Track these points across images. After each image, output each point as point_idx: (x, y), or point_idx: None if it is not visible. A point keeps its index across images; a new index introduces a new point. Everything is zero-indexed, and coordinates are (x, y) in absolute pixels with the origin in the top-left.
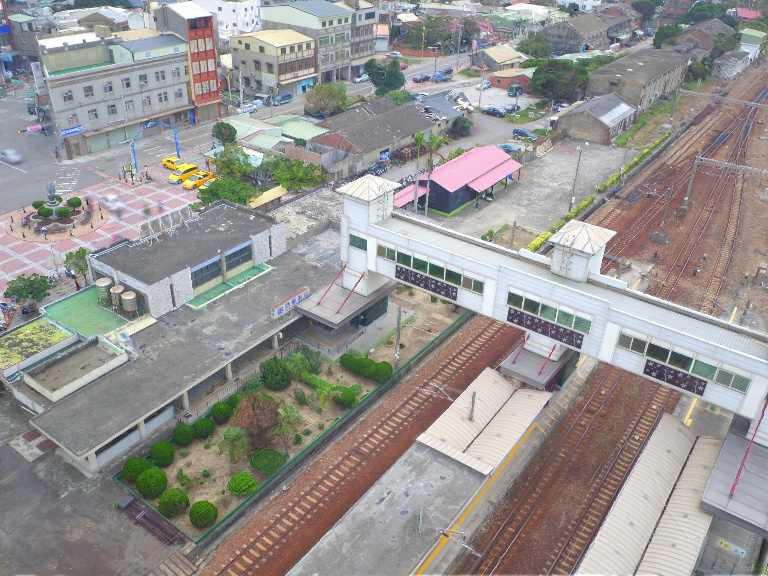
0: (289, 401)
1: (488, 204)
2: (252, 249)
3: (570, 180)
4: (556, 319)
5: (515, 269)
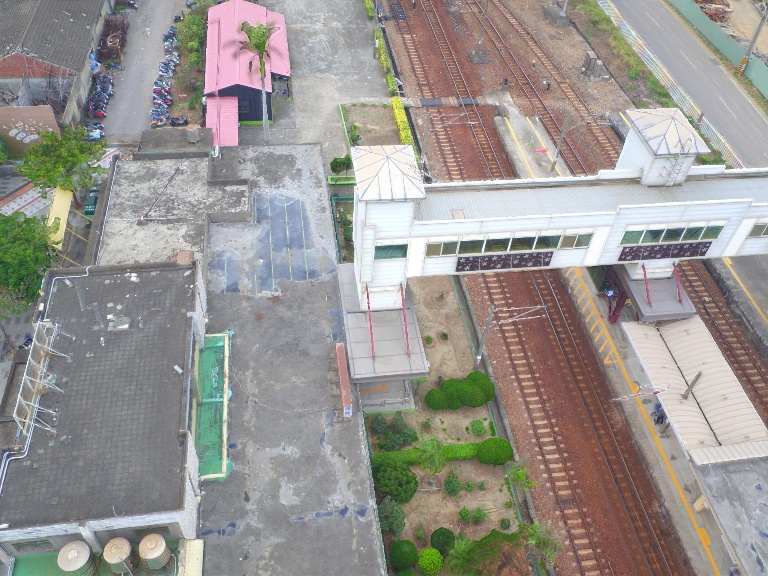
0: (437, 500)
1: (290, 85)
2: (194, 329)
3: (327, 13)
4: (681, 238)
5: (639, 205)
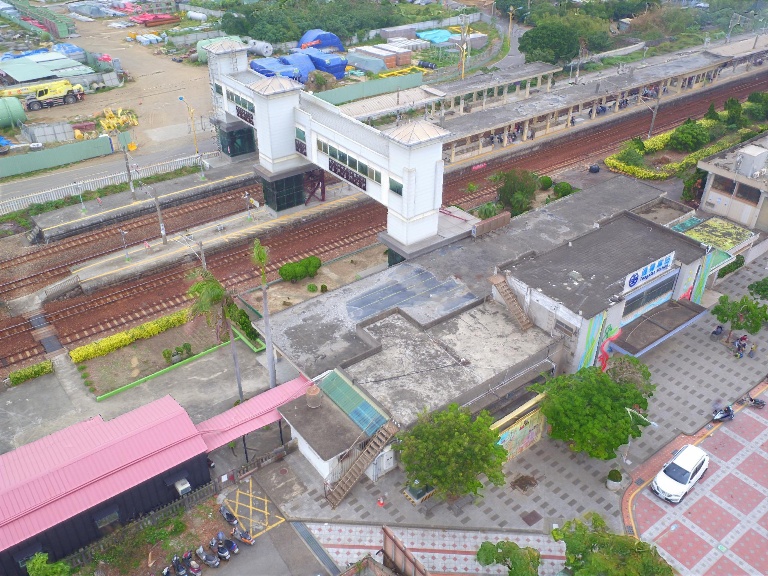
0: None
1: None
2: None
3: None
4: None
5: None
